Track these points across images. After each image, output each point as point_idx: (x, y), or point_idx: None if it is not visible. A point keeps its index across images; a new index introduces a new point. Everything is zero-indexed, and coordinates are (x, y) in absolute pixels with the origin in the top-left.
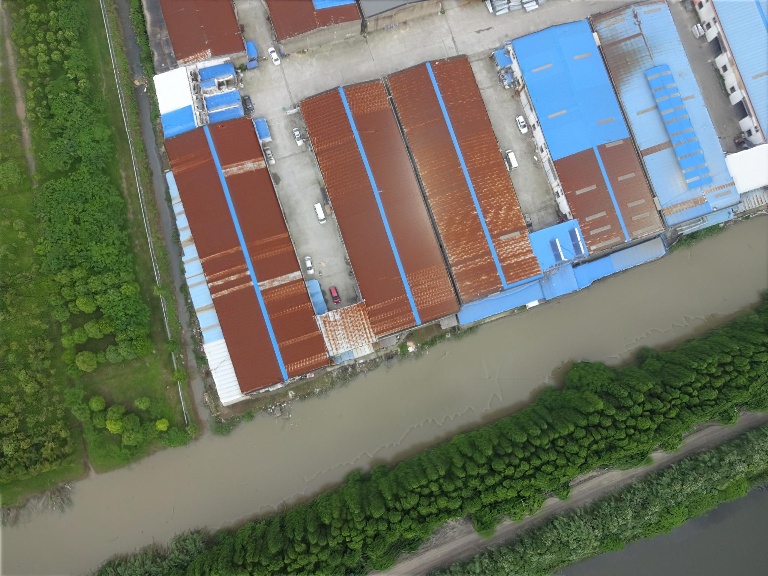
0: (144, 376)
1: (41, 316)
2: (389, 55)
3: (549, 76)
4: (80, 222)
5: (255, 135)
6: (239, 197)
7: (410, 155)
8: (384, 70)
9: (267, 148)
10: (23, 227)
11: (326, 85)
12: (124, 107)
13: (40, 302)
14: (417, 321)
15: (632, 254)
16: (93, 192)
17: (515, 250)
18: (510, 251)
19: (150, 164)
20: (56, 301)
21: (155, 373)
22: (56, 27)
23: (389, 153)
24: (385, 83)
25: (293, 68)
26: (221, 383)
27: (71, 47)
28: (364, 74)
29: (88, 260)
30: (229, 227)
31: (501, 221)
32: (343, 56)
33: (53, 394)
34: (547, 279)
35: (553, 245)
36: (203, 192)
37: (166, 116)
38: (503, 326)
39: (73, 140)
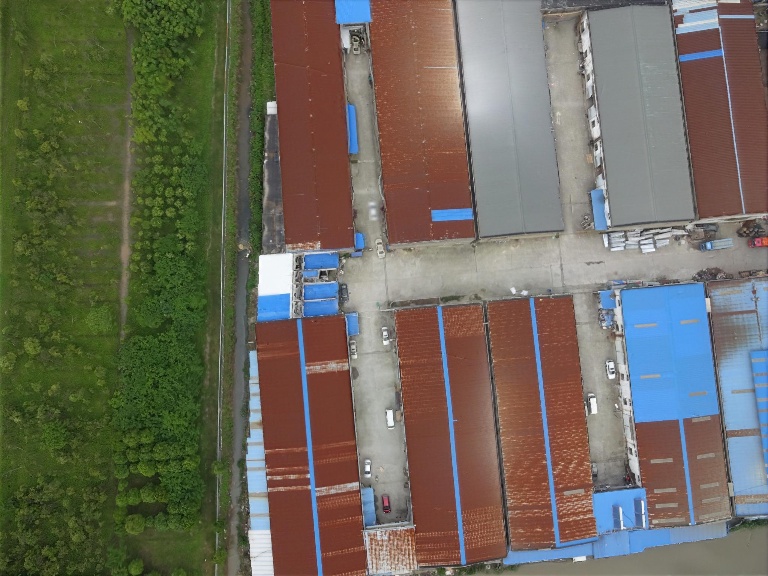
0: (185, 545)
1: (101, 465)
2: (494, 270)
3: (651, 335)
4: (158, 386)
5: (345, 335)
6: (316, 397)
7: (493, 386)
8: (485, 284)
9: (353, 342)
10: (103, 376)
11: (424, 288)
12: (224, 271)
13: (103, 450)
14: (462, 560)
15: (692, 530)
16: (177, 357)
17: (576, 508)
18: (571, 508)
19: (236, 331)
20: (119, 461)
21: (196, 544)
22: (177, 183)
23: (473, 382)
24: (484, 308)
25: (396, 264)
26: (257, 573)
27: (187, 206)
28: (464, 284)
29: (158, 425)
30: (300, 425)
31: (568, 475)
32: (448, 262)
33: (96, 547)
34: (600, 538)
35: (615, 511)
36: (282, 384)
37: (263, 299)
38: (545, 570)
39: (169, 303)
